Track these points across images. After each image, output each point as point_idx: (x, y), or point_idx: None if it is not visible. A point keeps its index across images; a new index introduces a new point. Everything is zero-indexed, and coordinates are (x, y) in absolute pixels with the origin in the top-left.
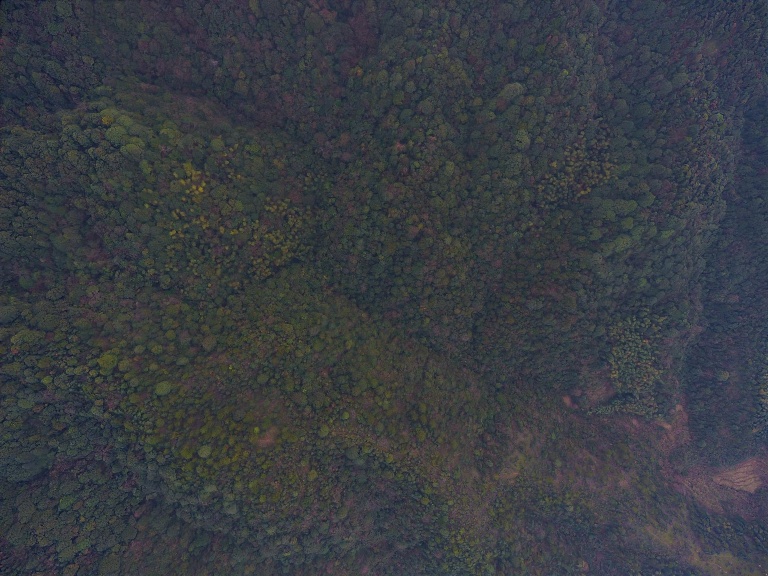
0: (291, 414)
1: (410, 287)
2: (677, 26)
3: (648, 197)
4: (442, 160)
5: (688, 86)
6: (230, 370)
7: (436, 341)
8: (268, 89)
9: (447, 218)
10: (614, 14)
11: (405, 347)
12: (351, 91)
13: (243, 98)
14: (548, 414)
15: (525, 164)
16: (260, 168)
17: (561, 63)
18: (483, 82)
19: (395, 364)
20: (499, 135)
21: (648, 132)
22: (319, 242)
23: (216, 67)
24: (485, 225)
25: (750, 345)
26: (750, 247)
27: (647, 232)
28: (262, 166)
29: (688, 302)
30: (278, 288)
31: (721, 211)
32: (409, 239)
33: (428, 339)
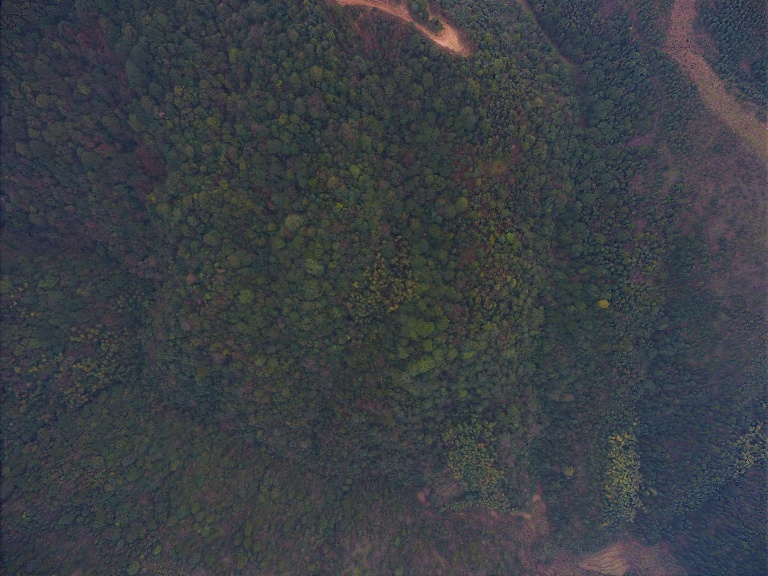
0: (100, 552)
1: (234, 404)
2: (454, 151)
3: (442, 321)
4: (236, 289)
5: (472, 209)
6: (23, 518)
7: (276, 449)
8: (65, 219)
9: (259, 338)
10: (395, 138)
11: (241, 459)
12: (151, 215)
13: (43, 227)
14: (394, 517)
15: (324, 287)
16: (59, 301)
17: (334, 197)
18: (274, 207)
19: (226, 481)
20: (293, 261)
21: (440, 254)
22: (144, 359)
23: (4, 203)
24: (302, 341)
25: (591, 441)
26: (572, 352)
27: (447, 354)
28: (62, 298)
29: (520, 405)
30: (91, 417)
31: (535, 320)
32: (218, 364)
33: (268, 447)
